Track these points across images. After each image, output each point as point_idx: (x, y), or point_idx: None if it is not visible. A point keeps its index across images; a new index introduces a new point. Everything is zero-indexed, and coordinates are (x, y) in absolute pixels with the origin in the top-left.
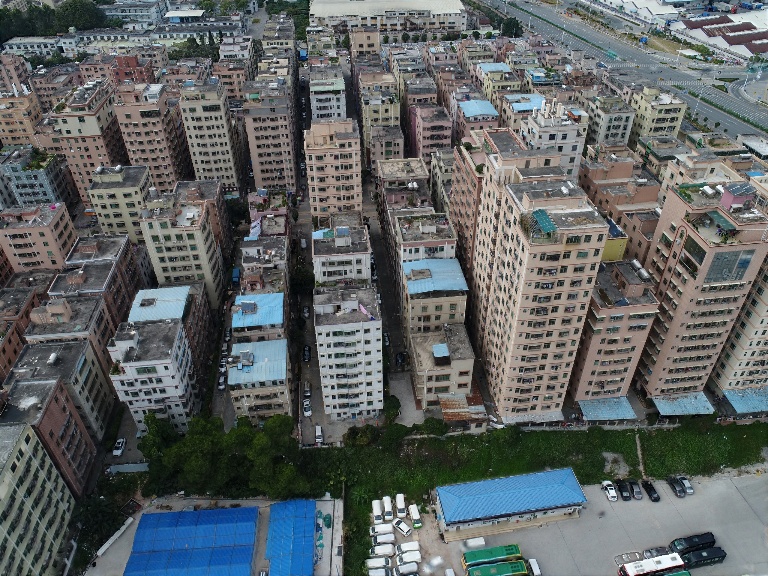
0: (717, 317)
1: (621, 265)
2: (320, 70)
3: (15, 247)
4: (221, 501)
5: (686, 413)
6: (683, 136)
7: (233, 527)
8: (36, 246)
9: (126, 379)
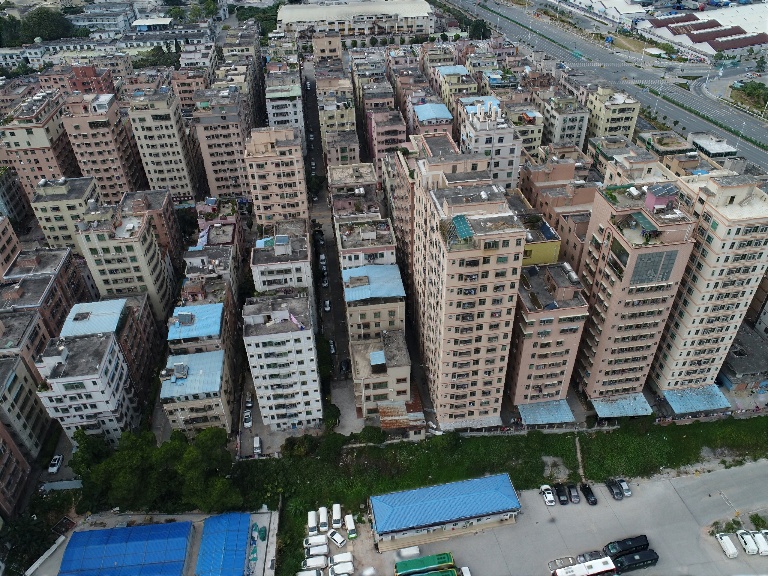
0: (648, 318)
1: (553, 268)
2: (277, 76)
3: None
4: (156, 516)
5: (624, 415)
6: None
7: (164, 543)
8: None
9: (54, 395)
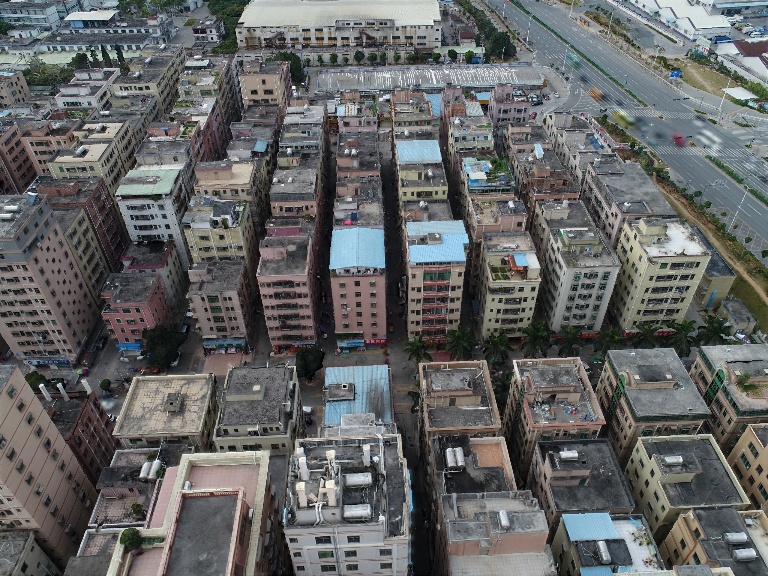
0: None
1: None
2: (150, 152)
3: None
4: None
5: None
6: (706, 280)
7: None
8: None
9: None
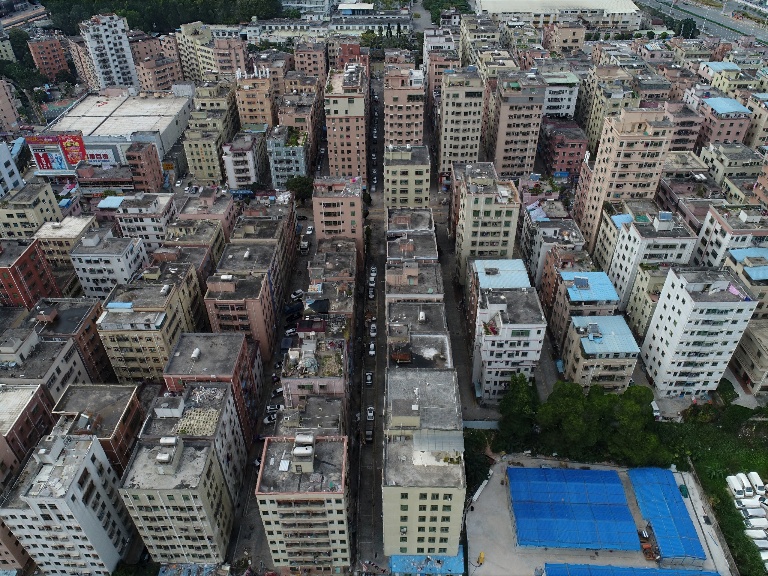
0: None
1: None
2: (548, 63)
3: (325, 215)
4: (569, 463)
5: None
6: None
7: (602, 487)
8: (343, 215)
9: (498, 340)
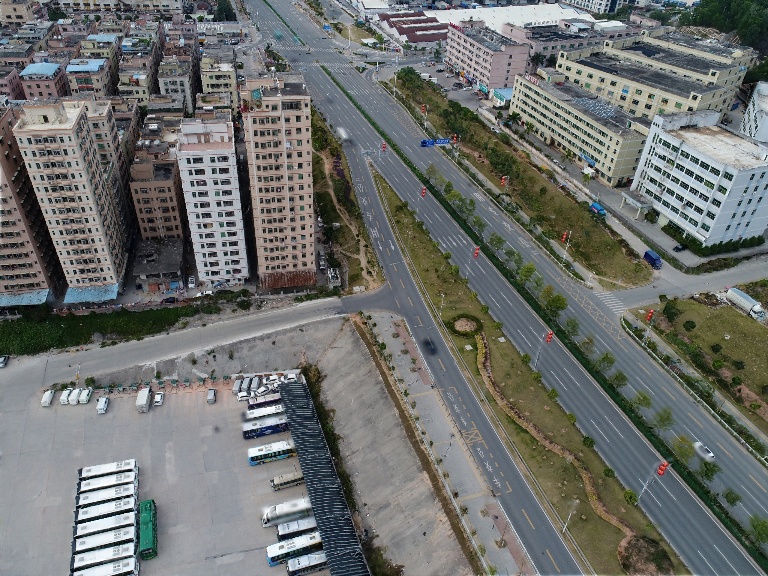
0: (1, 217)
1: None
2: None
3: None
4: None
5: (17, 304)
6: None
7: None
8: None
9: None
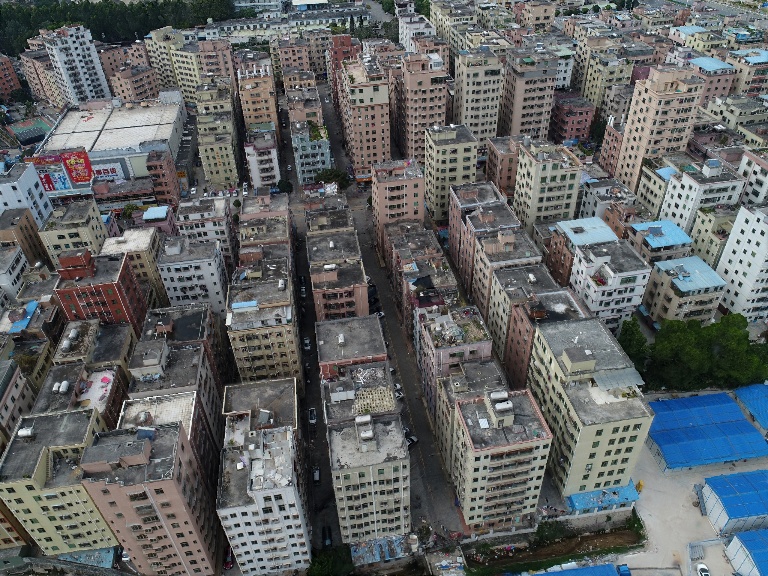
0: None
1: None
2: (538, 39)
3: (389, 199)
4: (678, 394)
5: None
6: None
7: (720, 408)
8: (407, 197)
9: (608, 289)
